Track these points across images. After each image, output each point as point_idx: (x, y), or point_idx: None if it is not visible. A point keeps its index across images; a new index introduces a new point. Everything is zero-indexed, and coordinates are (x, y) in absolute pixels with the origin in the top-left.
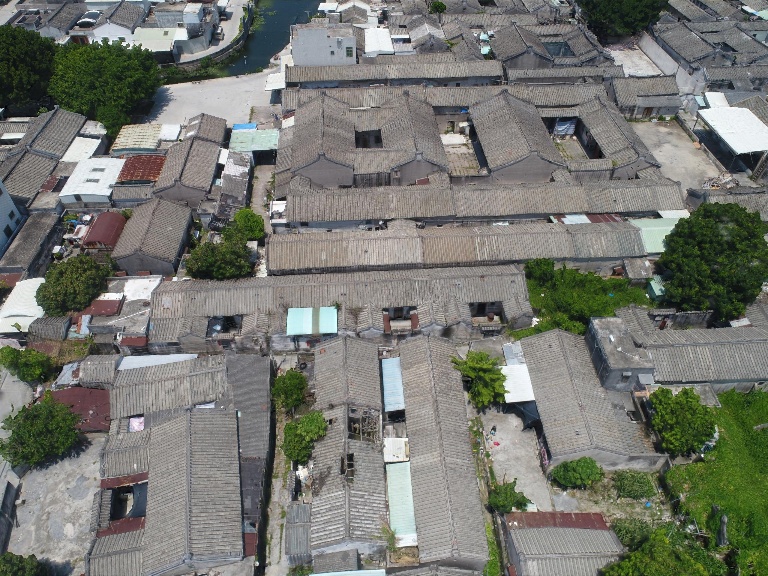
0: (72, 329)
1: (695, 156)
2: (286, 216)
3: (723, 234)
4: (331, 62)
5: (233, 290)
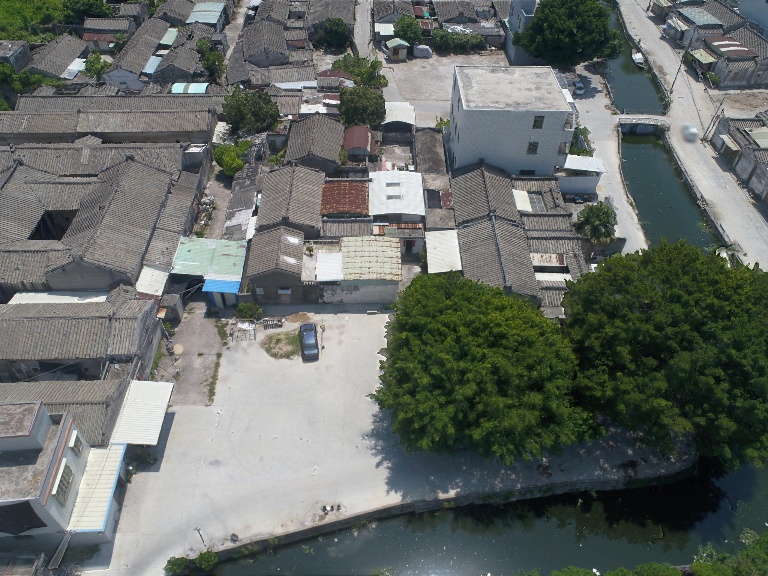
0: None
1: None
2: None
3: None
4: None
5: None
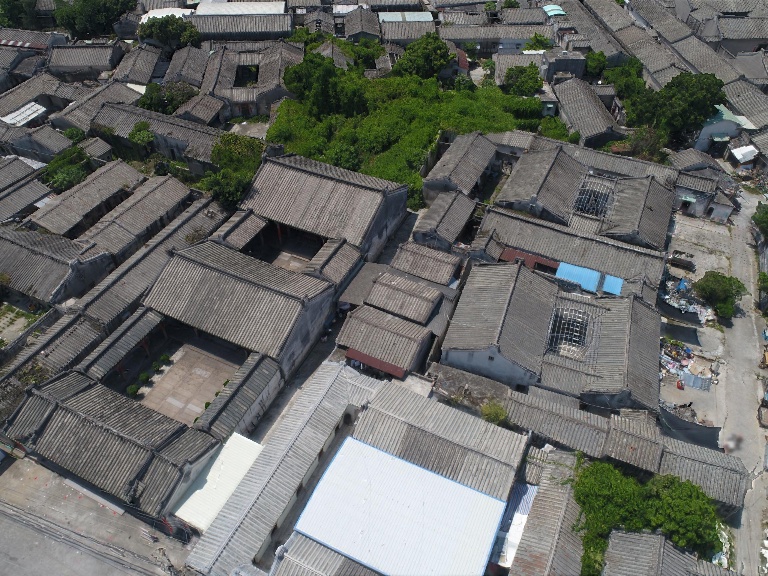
0: None
1: None
2: None
3: None
4: None
5: None
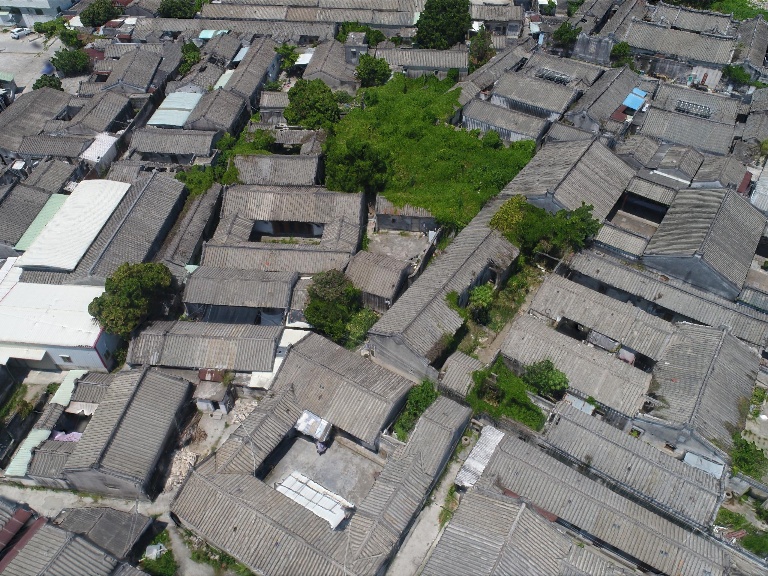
0: (95, 32)
1: (503, 3)
2: None
3: (440, 2)
4: None
5: (178, 20)
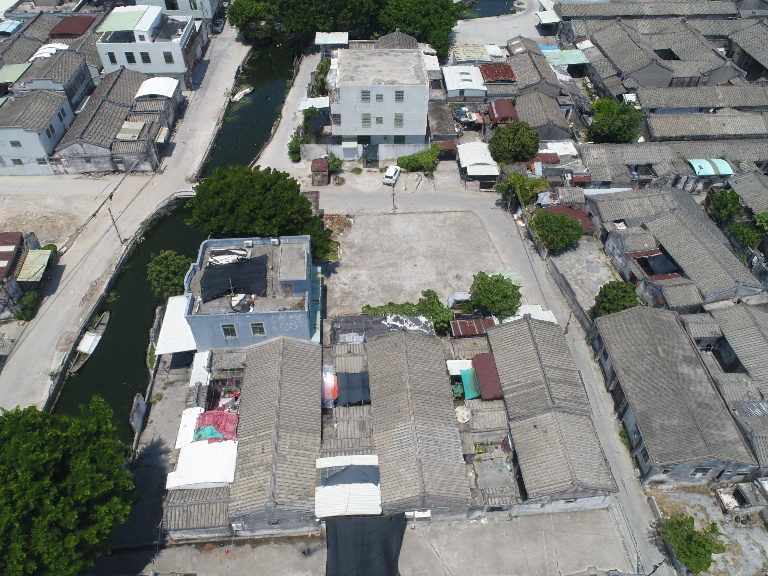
0: (528, 172)
1: None
2: (640, 104)
3: None
4: (589, 2)
5: (641, 147)
